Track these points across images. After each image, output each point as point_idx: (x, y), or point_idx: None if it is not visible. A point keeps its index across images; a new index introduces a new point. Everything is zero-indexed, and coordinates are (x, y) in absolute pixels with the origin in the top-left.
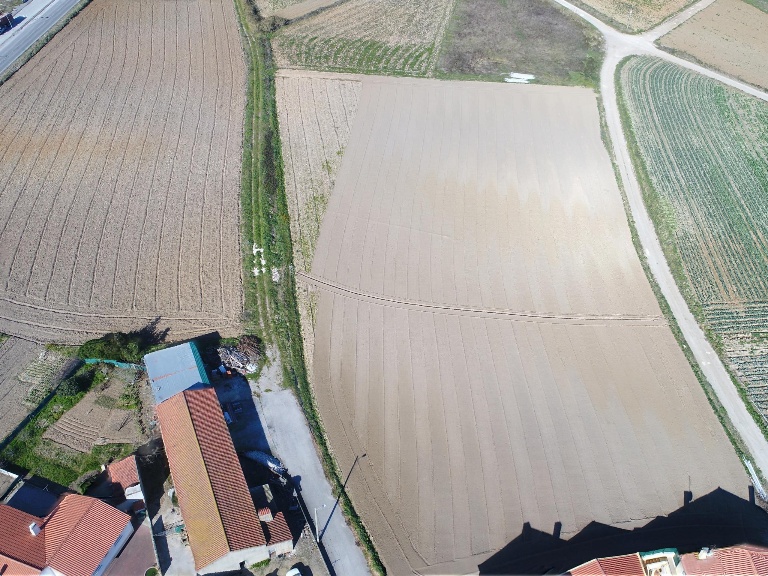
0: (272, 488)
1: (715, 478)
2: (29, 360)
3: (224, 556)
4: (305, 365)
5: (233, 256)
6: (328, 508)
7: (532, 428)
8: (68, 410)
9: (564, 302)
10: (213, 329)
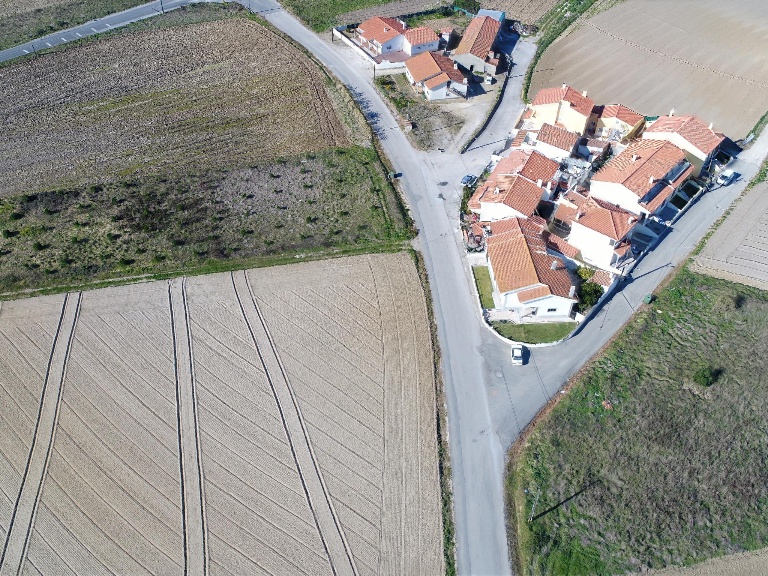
0: (501, 58)
1: (725, 131)
2: (432, 2)
3: (466, 54)
4: (552, 42)
5: (552, 3)
6: (520, 74)
7: (645, 89)
8: (437, 19)
9: (724, 67)
10: (519, 20)
